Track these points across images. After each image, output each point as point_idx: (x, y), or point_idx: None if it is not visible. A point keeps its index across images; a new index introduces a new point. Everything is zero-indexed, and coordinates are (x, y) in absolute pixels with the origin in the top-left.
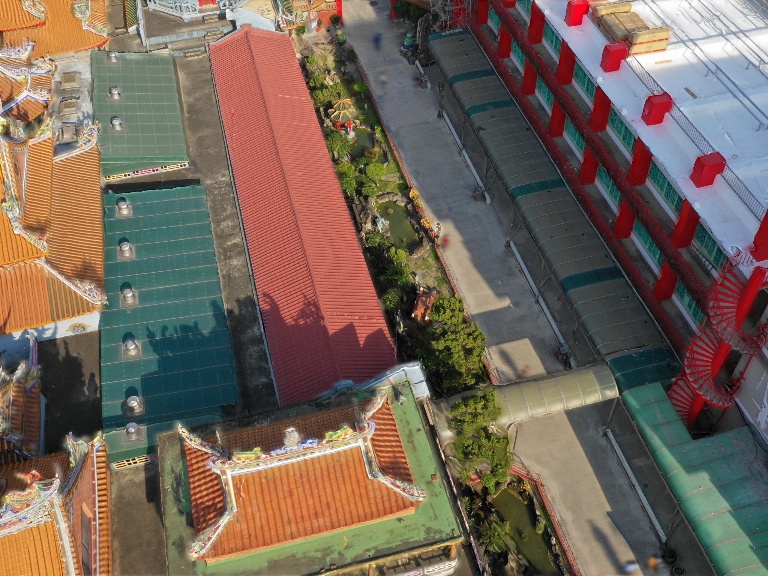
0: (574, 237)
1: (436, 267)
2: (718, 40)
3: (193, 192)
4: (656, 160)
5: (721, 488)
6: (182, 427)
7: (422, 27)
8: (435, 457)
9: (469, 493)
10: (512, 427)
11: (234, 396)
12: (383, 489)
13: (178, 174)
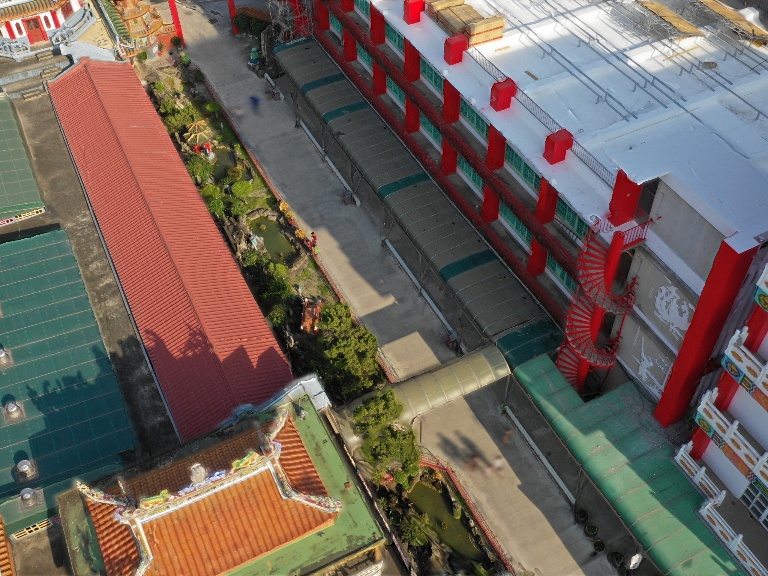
0: (445, 227)
1: (317, 276)
2: (549, 22)
3: (54, 238)
4: (510, 143)
5: (617, 443)
6: (81, 484)
7: (266, 40)
8: (345, 465)
9: (384, 493)
10: (416, 421)
11: (131, 441)
12: (299, 507)
13: (35, 221)
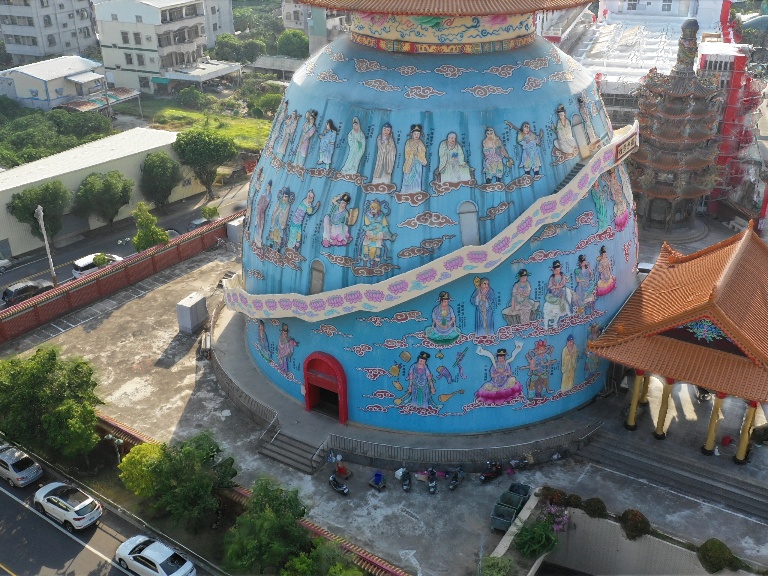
0: None
1: None
2: (675, 41)
3: None
4: None
5: None
6: None
7: None
8: None
9: None
10: None
11: None
12: None
13: None
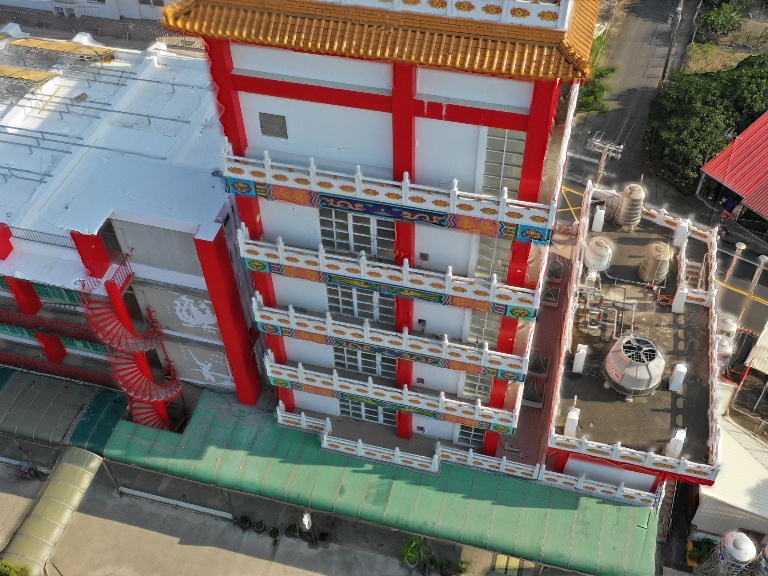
0: None
1: None
2: None
3: None
4: None
5: (230, 446)
6: None
7: None
8: None
9: None
10: (47, 568)
11: None
12: None
13: None
